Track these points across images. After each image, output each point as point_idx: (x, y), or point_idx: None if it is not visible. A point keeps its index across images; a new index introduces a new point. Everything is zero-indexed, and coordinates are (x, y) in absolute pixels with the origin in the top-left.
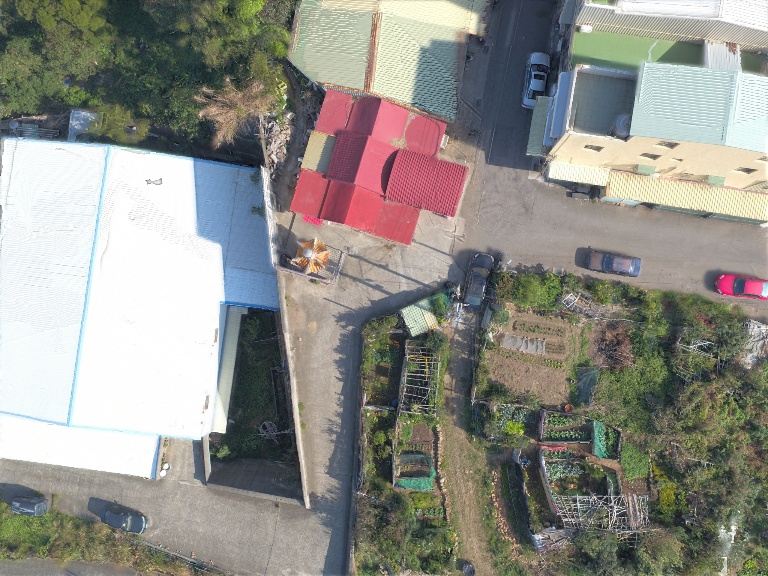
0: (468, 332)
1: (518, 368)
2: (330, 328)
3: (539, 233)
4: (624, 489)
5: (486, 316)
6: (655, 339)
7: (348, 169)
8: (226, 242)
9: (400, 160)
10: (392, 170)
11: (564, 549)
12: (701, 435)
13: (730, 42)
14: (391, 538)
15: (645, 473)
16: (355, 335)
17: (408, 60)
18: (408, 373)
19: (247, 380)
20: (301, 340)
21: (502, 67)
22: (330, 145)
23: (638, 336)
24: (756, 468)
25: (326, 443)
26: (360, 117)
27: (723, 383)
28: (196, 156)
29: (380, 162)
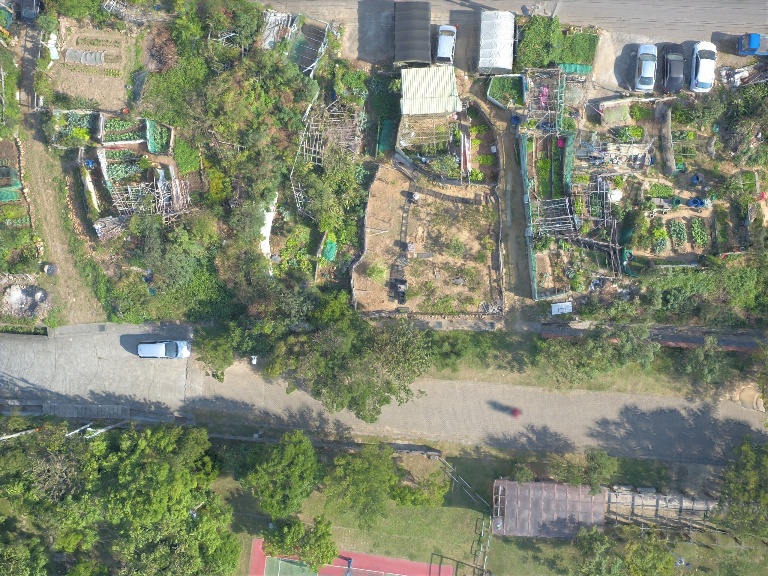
0: (36, 49)
1: (82, 79)
2: None
3: None
4: None
5: None
6: (197, 41)
7: None
8: None
9: None
10: None
11: (129, 241)
12: (230, 119)
13: None
14: None
15: (197, 166)
16: None
17: None
18: None
19: None
20: None
21: None
22: None
23: (180, 38)
24: (284, 148)
25: None
26: None
27: (241, 66)
28: None
29: None
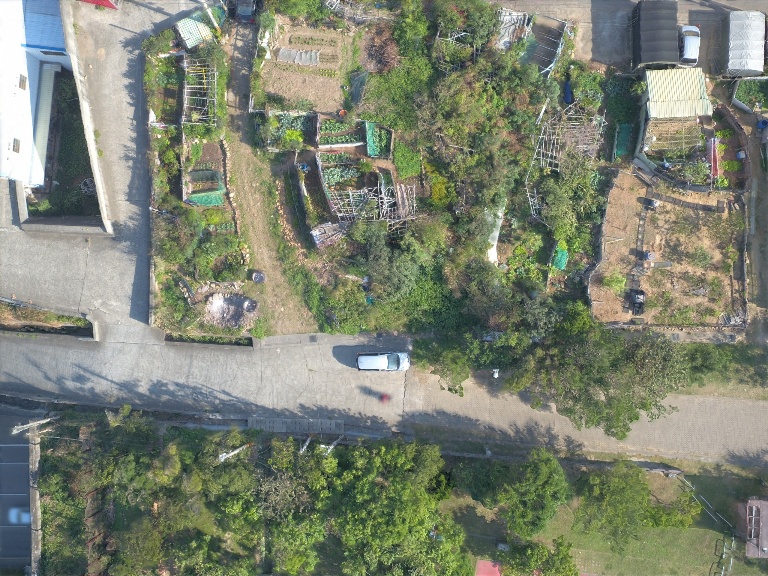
0: (247, 48)
1: (295, 80)
2: (118, 54)
3: None
4: None
5: None
6: (420, 40)
7: None
8: None
9: None
10: None
11: None
12: (461, 122)
13: None
14: (176, 240)
15: (418, 171)
16: (142, 59)
17: None
18: (187, 85)
19: (68, 141)
20: (92, 67)
21: None
22: None
23: (403, 37)
24: (516, 152)
25: (124, 170)
26: None
27: (476, 67)
28: None
29: None
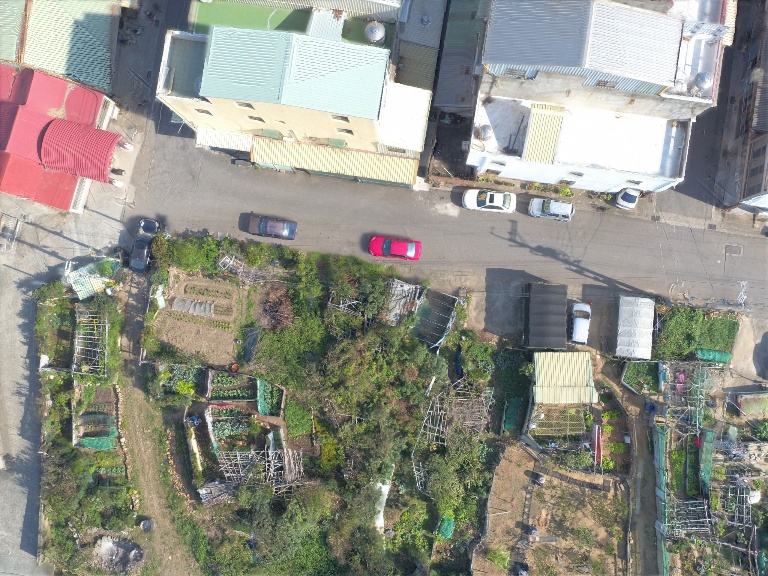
0: (141, 296)
1: (189, 330)
2: (12, 294)
3: (205, 199)
4: (289, 445)
5: None
6: (315, 300)
7: (3, 138)
8: None
9: (53, 129)
10: (44, 138)
11: (233, 504)
12: None
13: (336, 9)
14: (60, 494)
15: (308, 429)
16: None
17: (62, 33)
18: (78, 335)
19: None
20: None
21: None
22: None
23: (297, 297)
24: (405, 422)
25: (16, 406)
26: (20, 88)
27: (365, 340)
28: None
29: (34, 131)
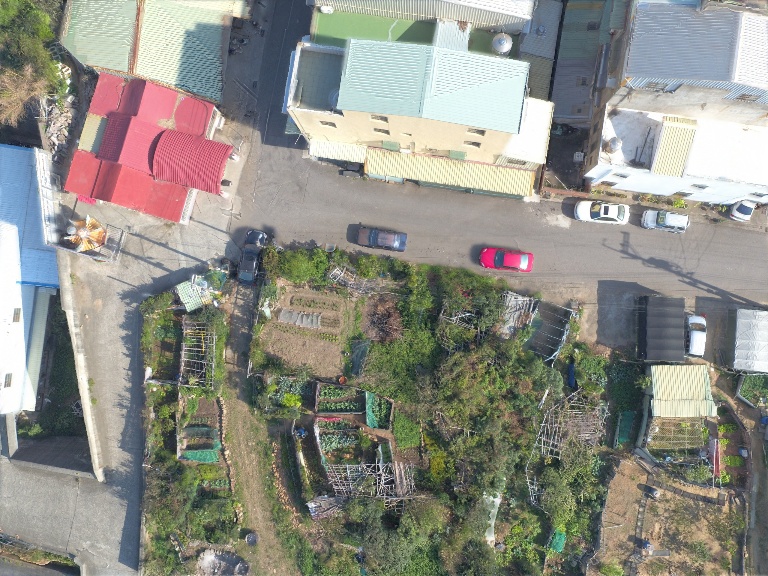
0: (247, 307)
1: (295, 342)
2: (115, 305)
3: (312, 210)
4: (397, 458)
5: (261, 291)
6: (424, 312)
7: (114, 149)
8: (22, 224)
9: (165, 140)
10: (156, 149)
11: (340, 517)
12: None
13: (461, 20)
14: (168, 508)
15: (417, 442)
16: (139, 312)
17: (173, 43)
18: (185, 347)
19: (62, 360)
20: (88, 317)
21: (277, 50)
22: (102, 126)
23: (406, 309)
24: (517, 435)
25: (117, 418)
26: (129, 99)
27: (480, 353)
28: (6, 141)
29: (146, 142)
